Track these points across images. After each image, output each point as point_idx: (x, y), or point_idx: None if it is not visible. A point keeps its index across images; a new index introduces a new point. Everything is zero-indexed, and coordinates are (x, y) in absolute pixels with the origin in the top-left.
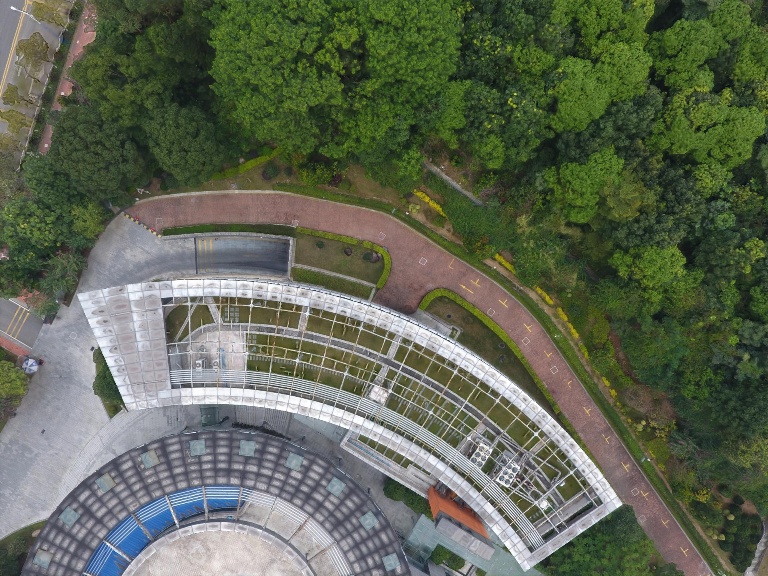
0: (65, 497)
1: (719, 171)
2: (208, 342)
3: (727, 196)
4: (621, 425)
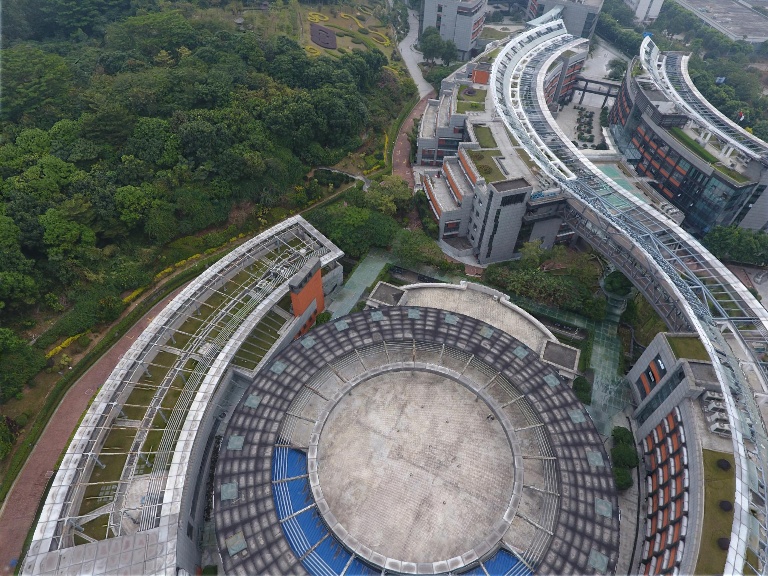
0: None
1: (75, 173)
2: (116, 493)
3: None
4: None
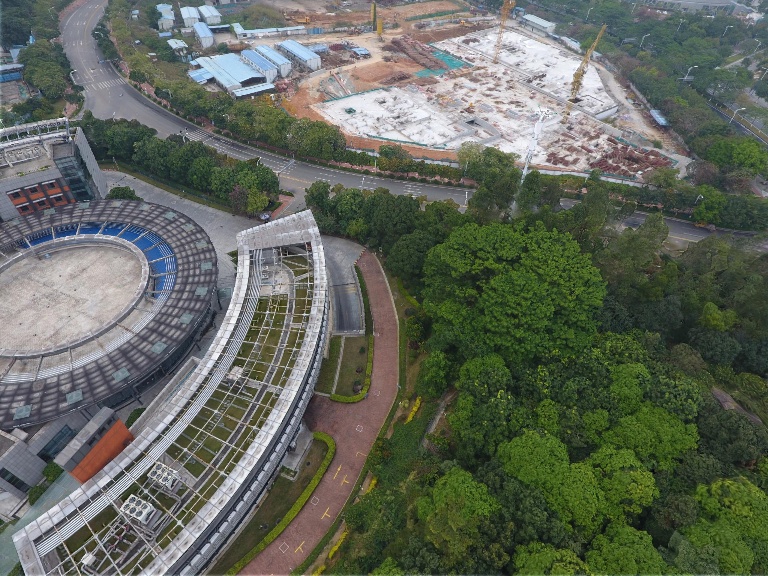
0: None
1: None
2: None
3: None
4: None
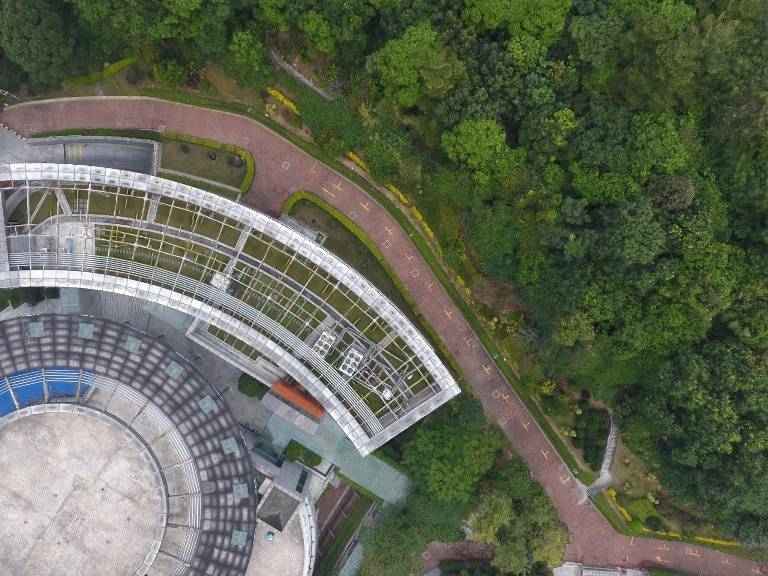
0: None
1: (529, 42)
2: (46, 225)
3: (544, 71)
4: (478, 325)
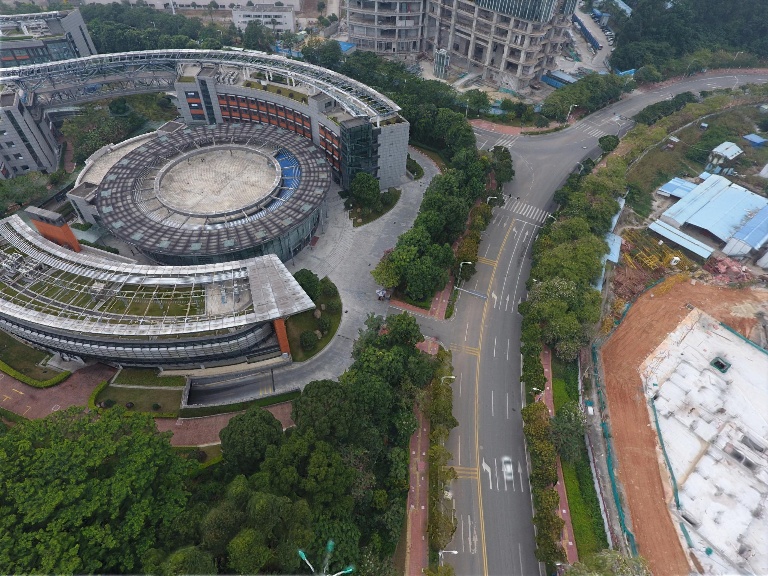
0: (310, 215)
1: None
2: None
3: None
4: None
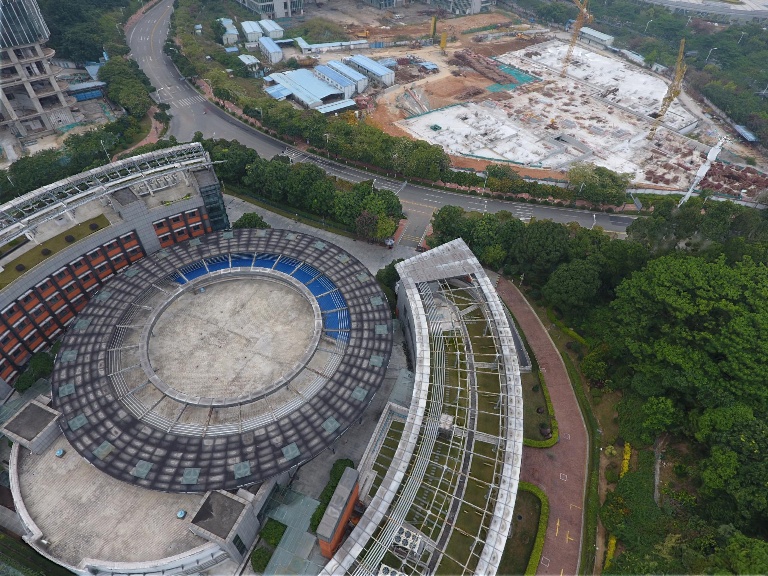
0: None
1: None
2: None
3: None
4: None
